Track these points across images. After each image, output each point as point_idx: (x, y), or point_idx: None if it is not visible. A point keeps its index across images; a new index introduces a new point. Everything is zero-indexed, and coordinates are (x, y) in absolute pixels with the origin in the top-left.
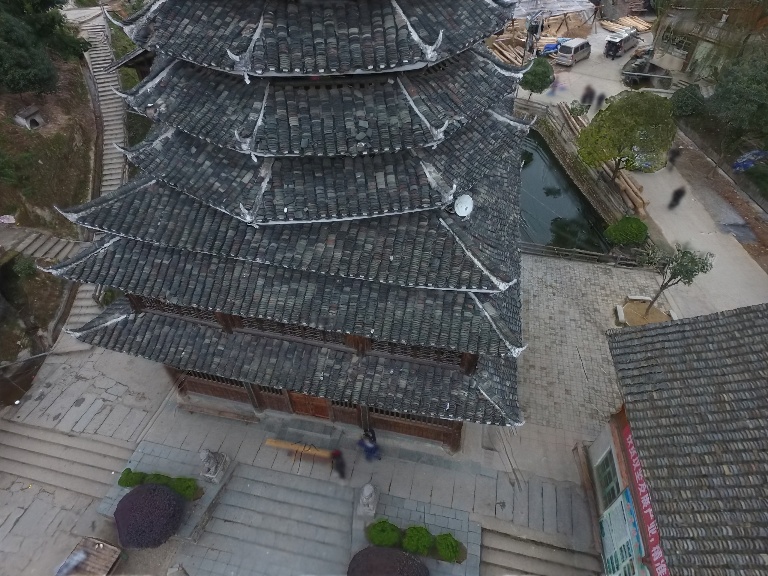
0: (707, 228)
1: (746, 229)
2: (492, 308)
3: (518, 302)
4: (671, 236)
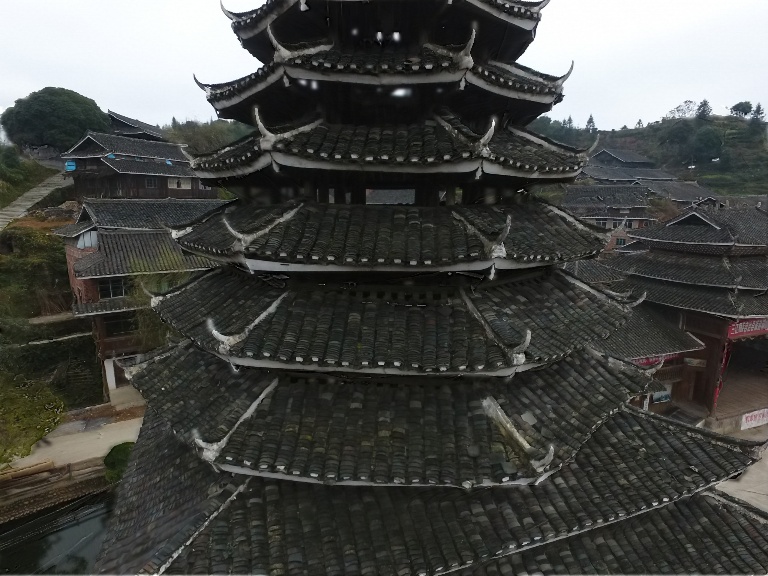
0: (92, 435)
1: (92, 421)
2: None
3: None
4: (107, 451)
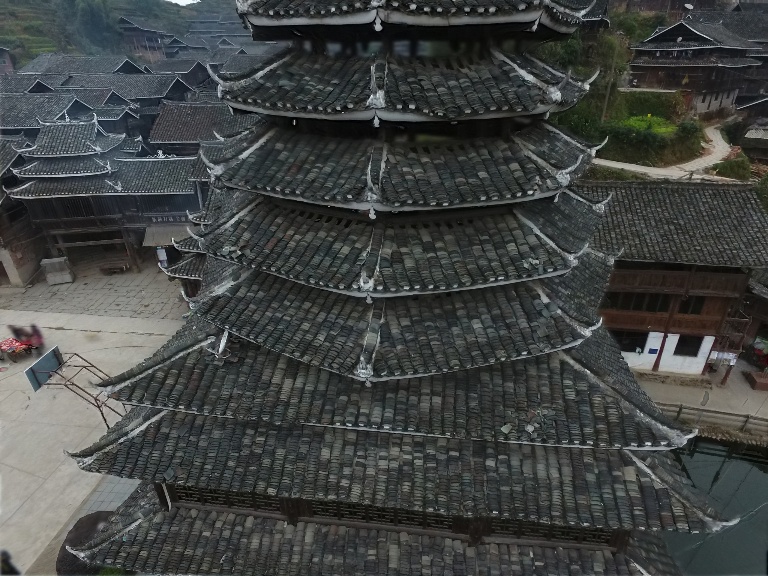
0: None
1: None
2: (134, 425)
3: (162, 475)
4: None
